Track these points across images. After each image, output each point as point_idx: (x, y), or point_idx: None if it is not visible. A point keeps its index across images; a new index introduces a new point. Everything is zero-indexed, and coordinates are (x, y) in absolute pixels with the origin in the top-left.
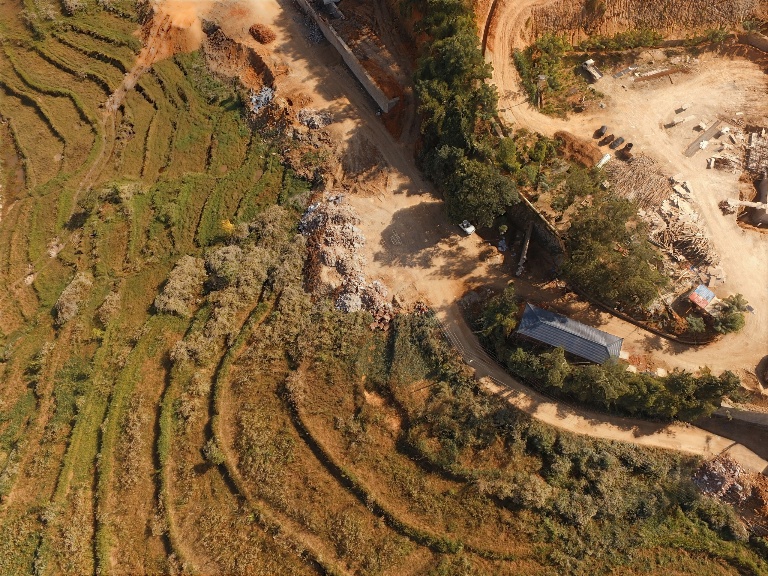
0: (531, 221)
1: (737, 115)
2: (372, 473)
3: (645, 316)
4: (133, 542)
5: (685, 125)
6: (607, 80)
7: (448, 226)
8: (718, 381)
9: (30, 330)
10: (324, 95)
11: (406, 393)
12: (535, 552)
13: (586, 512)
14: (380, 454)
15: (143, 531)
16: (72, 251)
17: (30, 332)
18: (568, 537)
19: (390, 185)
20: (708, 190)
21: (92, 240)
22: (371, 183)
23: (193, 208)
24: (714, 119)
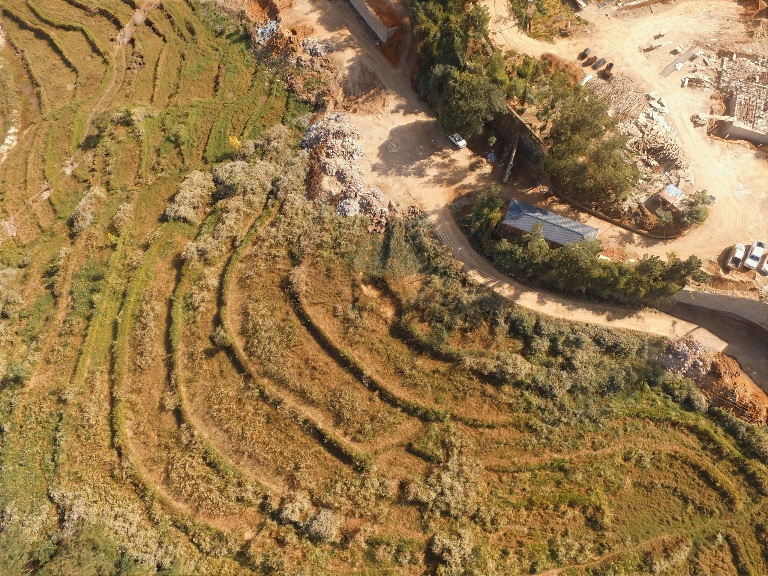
0: (518, 133)
1: (711, 41)
2: (368, 354)
3: (620, 214)
4: (147, 416)
5: (663, 49)
6: (592, 9)
7: (441, 141)
8: (682, 262)
9: (47, 239)
10: (326, 26)
11: (400, 285)
12: (515, 420)
13: (562, 384)
14: (375, 338)
15: (156, 407)
16: (86, 169)
17: (47, 241)
18: (545, 407)
19: (388, 105)
20: (681, 106)
21: (105, 159)
22: (370, 104)
23: (201, 129)
24: (690, 44)
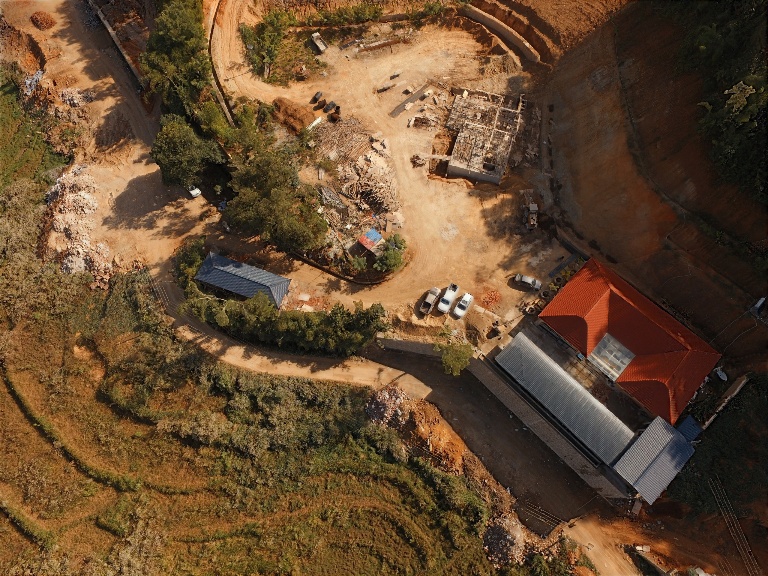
0: None
1: (444, 79)
2: (68, 422)
3: (327, 261)
4: None
5: (396, 89)
6: (333, 51)
7: (178, 190)
8: (361, 312)
9: None
10: (90, 76)
11: (111, 345)
12: (209, 484)
13: (257, 443)
14: (79, 404)
15: None
16: None
17: None
18: (241, 468)
19: (131, 155)
20: (404, 146)
21: None
22: (116, 154)
23: None
24: (423, 83)
